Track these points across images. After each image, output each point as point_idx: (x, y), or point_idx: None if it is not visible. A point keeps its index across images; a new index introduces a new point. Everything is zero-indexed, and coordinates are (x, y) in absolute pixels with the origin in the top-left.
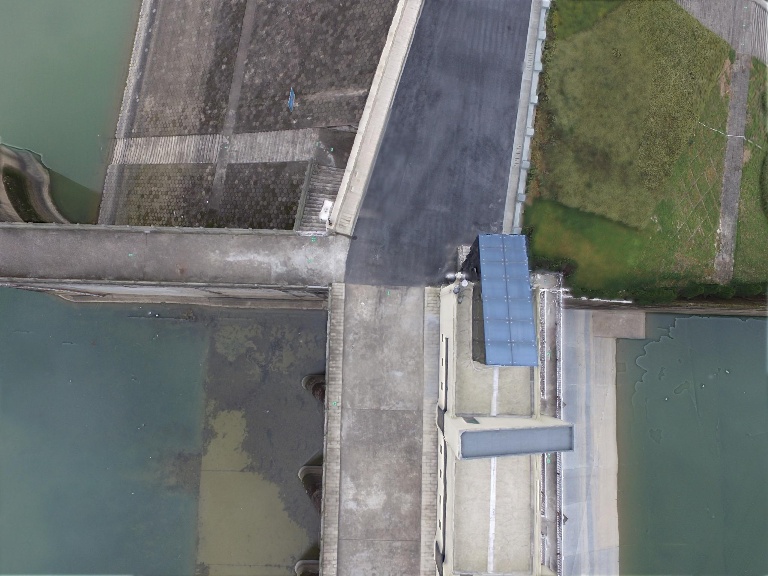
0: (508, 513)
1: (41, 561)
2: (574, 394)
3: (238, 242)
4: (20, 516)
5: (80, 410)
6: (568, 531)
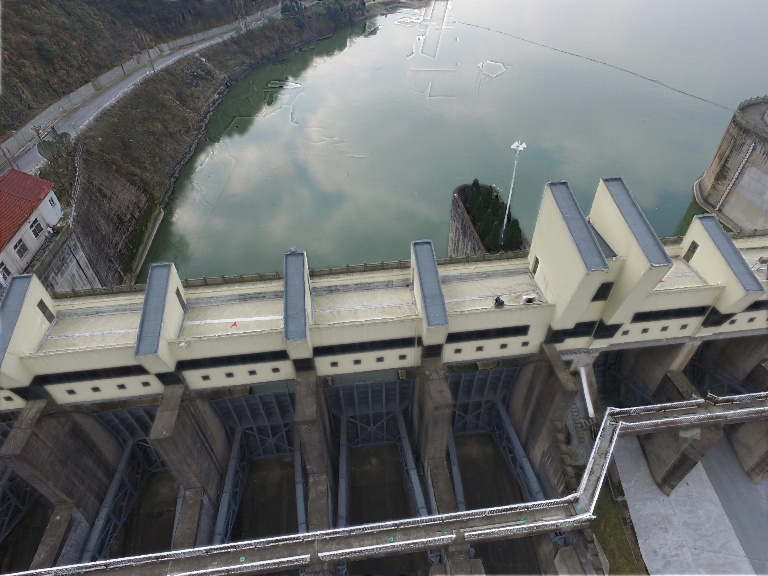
0: None
1: None
2: None
3: None
4: None
5: None
6: None
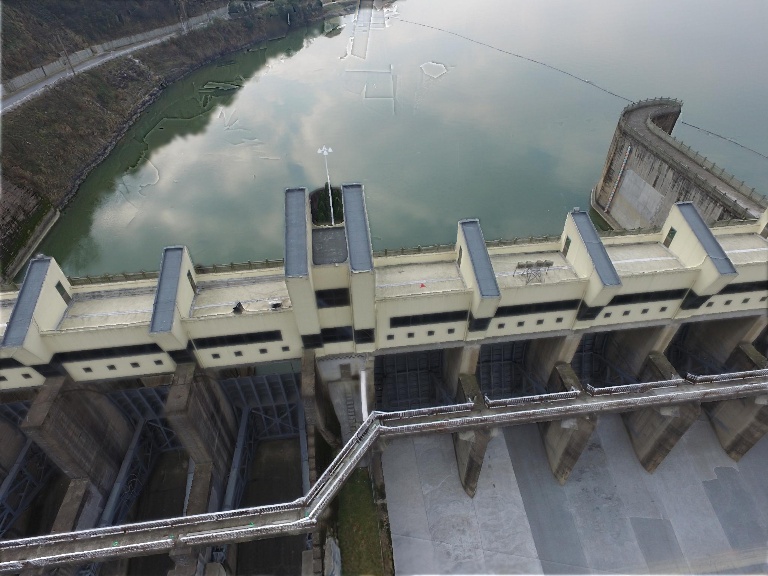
0: (740, 259)
1: (448, 215)
2: (764, 542)
3: (735, 193)
4: (466, 207)
5: (535, 216)
6: (611, 552)
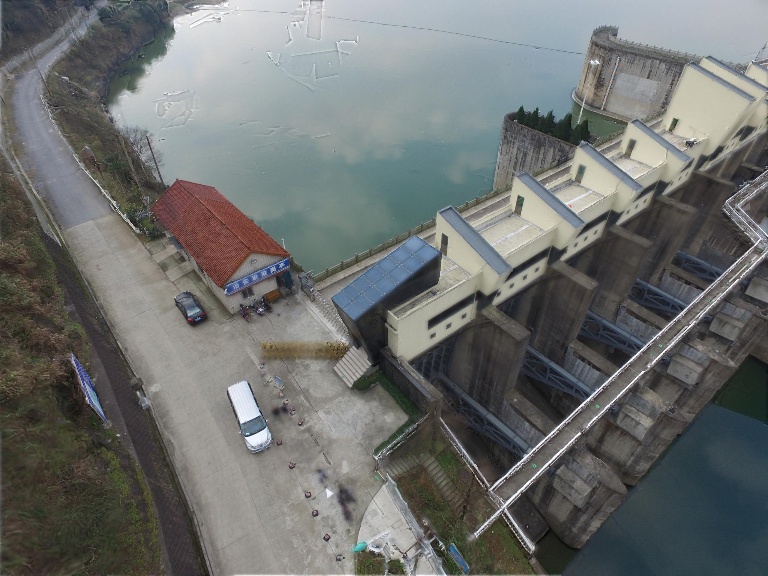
0: None
1: None
2: None
3: None
4: None
5: None
6: None
